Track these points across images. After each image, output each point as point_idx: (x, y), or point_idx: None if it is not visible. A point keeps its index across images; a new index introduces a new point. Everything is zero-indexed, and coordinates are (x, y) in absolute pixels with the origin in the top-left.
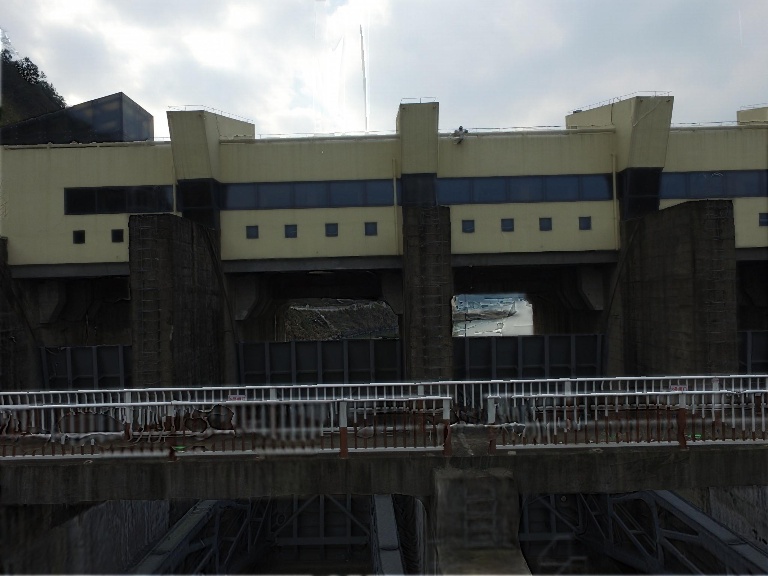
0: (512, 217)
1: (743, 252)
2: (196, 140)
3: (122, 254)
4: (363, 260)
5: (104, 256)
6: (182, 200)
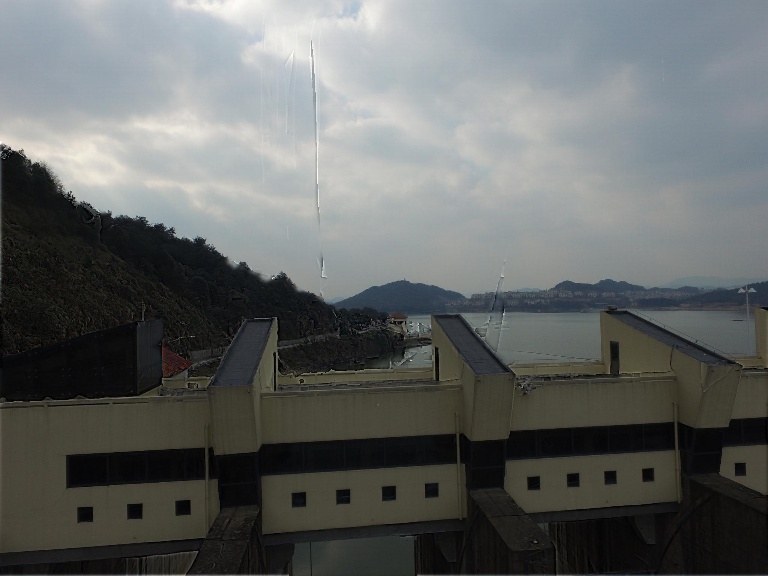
0: (578, 472)
1: None
2: (241, 415)
3: (140, 533)
4: (422, 524)
5: (117, 536)
6: (220, 476)
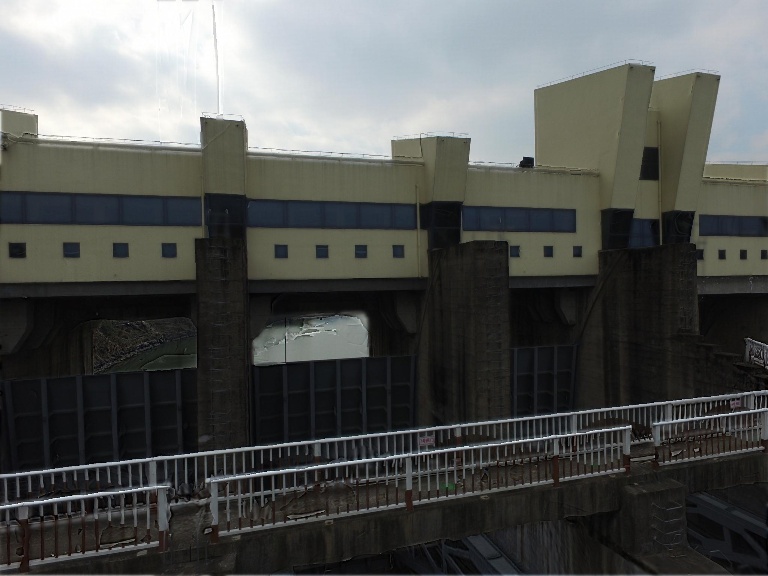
0: (78, 241)
1: (341, 283)
2: None
3: None
4: None
5: None
6: None
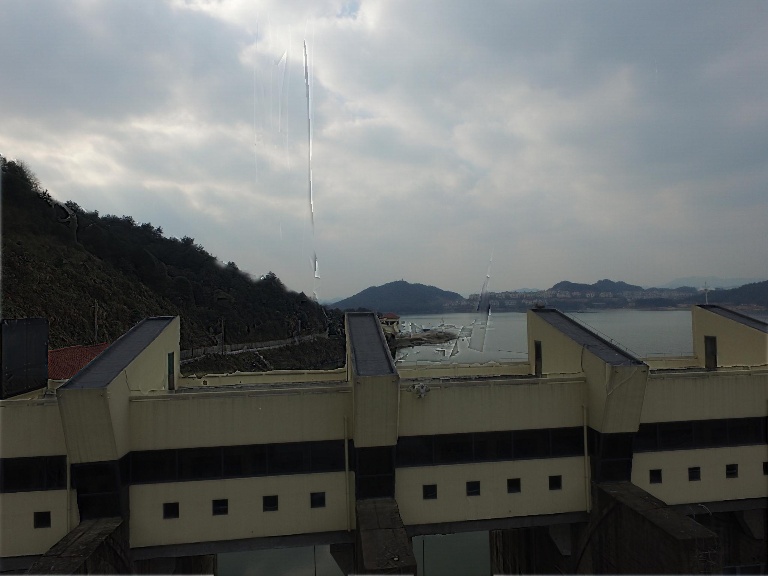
0: (478, 479)
1: (711, 505)
2: (97, 420)
3: None
4: (308, 536)
5: None
6: (77, 486)
